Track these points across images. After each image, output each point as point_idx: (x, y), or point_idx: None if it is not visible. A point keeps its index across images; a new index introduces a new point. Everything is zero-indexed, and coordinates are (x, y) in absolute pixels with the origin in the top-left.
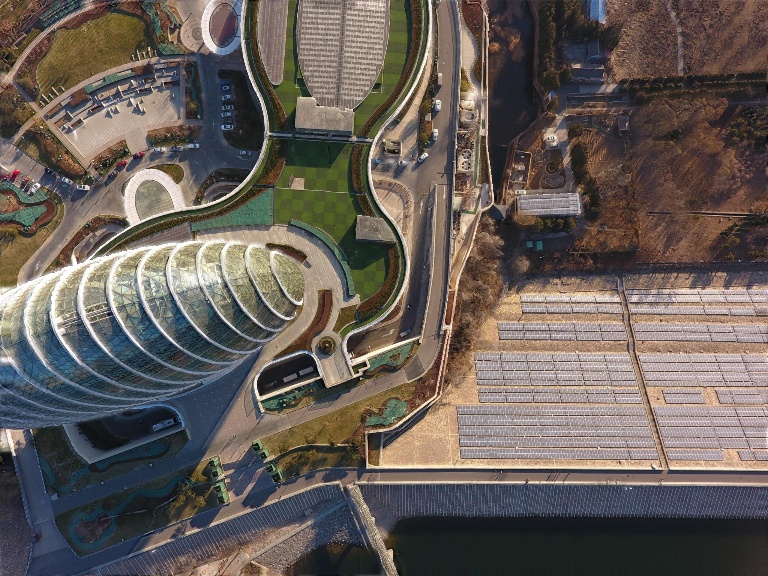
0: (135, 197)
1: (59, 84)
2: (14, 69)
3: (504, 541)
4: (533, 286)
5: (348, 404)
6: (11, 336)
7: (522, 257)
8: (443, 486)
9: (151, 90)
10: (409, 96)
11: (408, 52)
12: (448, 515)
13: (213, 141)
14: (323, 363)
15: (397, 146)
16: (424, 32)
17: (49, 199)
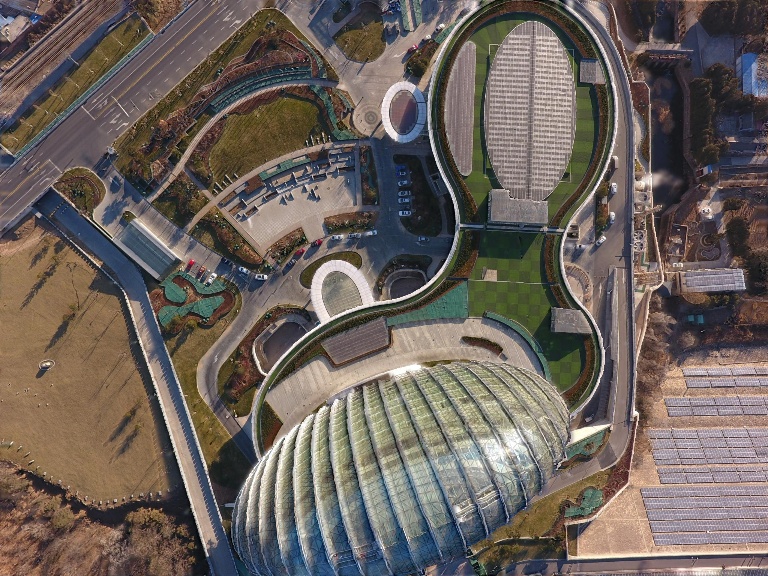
0: (321, 289)
1: (232, 171)
2: (185, 156)
3: None
4: (693, 359)
5: (546, 495)
6: (411, 529)
7: (688, 333)
8: (639, 573)
9: (326, 176)
10: (598, 185)
11: (595, 141)
12: None
13: (390, 227)
14: None
15: (575, 230)
16: (610, 120)
17: (226, 289)
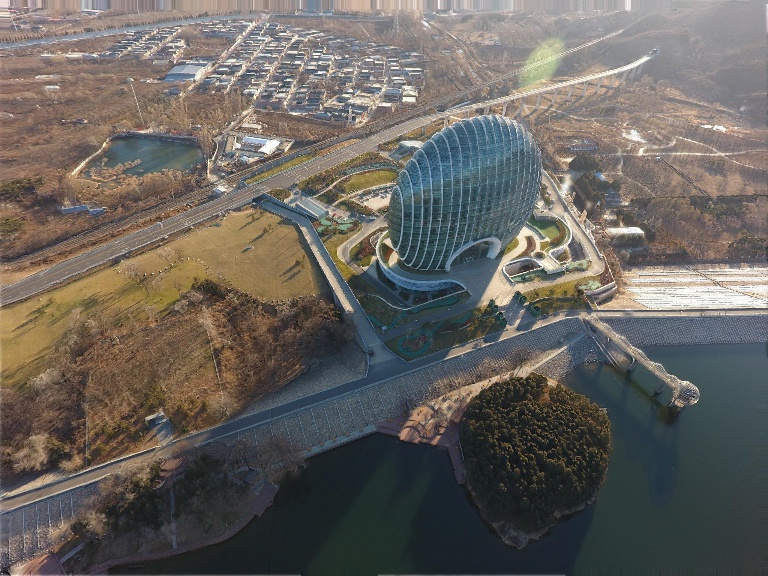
0: None
1: (356, 189)
2: (332, 185)
3: (711, 360)
4: (637, 269)
5: (564, 282)
6: None
7: (623, 251)
8: (648, 321)
9: None
10: None
11: None
12: (661, 345)
13: None
14: (541, 262)
15: (536, 204)
16: None
17: (354, 222)
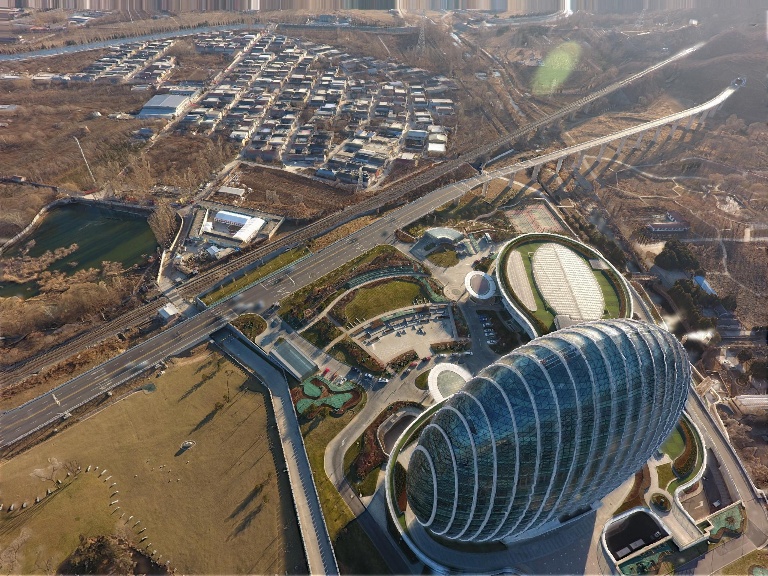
0: (437, 382)
1: (361, 317)
2: (328, 309)
3: None
4: None
5: (711, 573)
6: (595, 336)
7: None
8: None
9: (428, 321)
10: None
11: (618, 295)
12: None
13: (482, 351)
14: (665, 521)
15: None
16: (622, 286)
17: (355, 389)
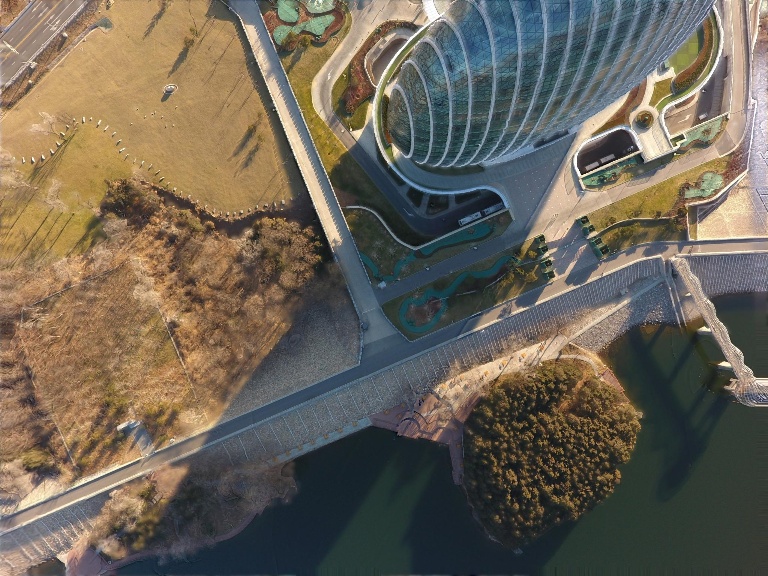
0: None
1: None
2: None
3: None
4: None
5: (664, 179)
6: None
7: None
8: (761, 257)
9: None
10: None
11: None
12: (760, 290)
13: None
14: (641, 137)
15: None
16: None
17: (336, 8)
